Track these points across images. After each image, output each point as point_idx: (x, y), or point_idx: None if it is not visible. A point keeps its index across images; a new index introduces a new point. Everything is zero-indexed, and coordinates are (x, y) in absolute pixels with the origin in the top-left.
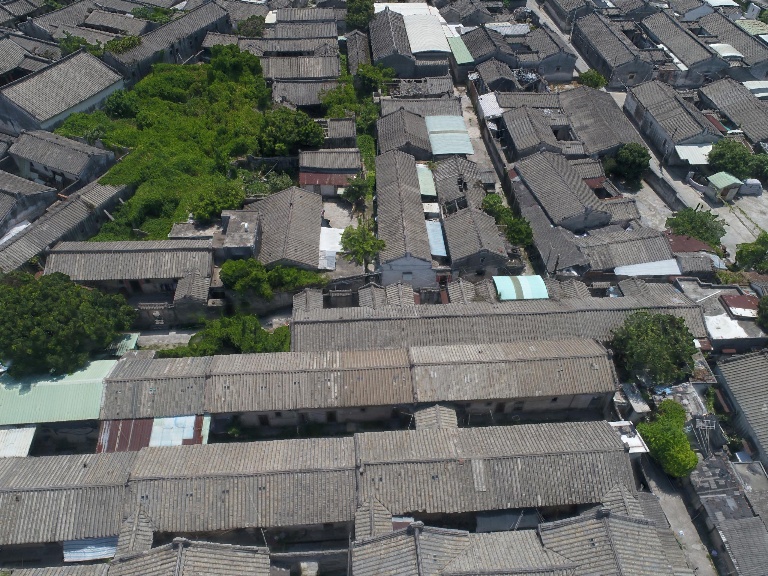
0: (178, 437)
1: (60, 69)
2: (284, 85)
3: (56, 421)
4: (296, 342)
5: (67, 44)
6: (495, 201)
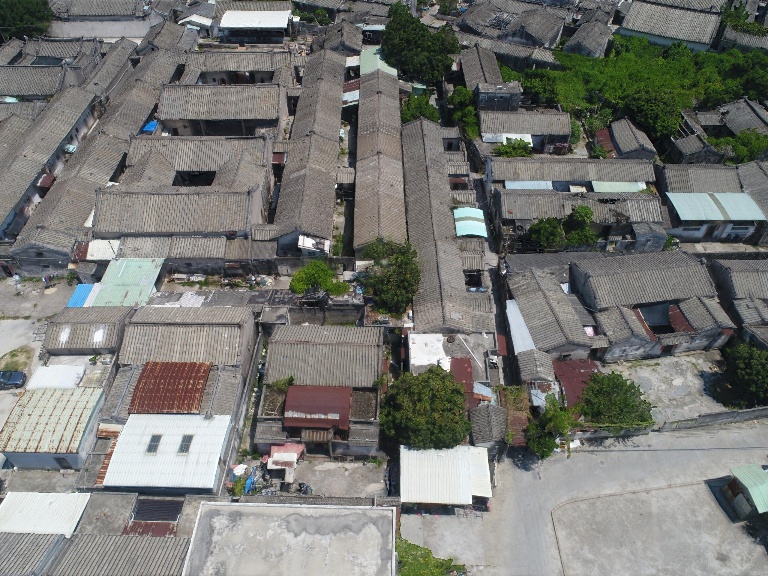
0: (349, 98)
1: (685, 14)
2: (744, 106)
3: (360, 66)
4: (409, 125)
5: (727, 9)
6: (578, 209)
